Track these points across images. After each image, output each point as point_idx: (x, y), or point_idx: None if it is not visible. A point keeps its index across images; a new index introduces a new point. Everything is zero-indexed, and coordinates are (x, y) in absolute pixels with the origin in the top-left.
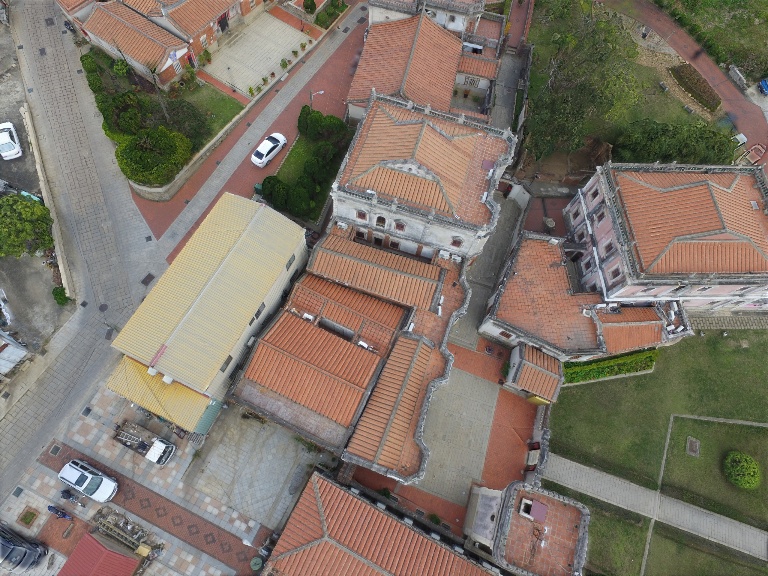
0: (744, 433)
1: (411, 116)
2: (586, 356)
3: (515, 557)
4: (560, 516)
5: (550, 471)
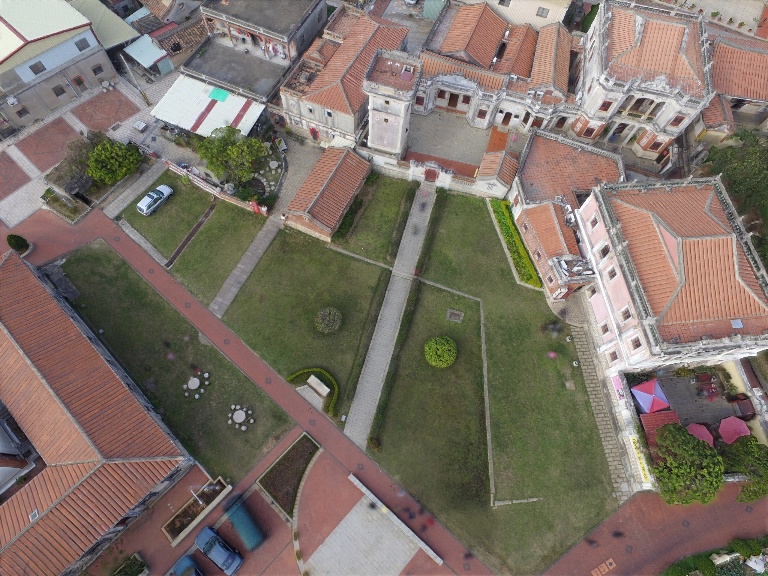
0: (475, 369)
1: (693, 39)
2: (519, 206)
3: (380, 64)
4: (405, 87)
5: (422, 198)
